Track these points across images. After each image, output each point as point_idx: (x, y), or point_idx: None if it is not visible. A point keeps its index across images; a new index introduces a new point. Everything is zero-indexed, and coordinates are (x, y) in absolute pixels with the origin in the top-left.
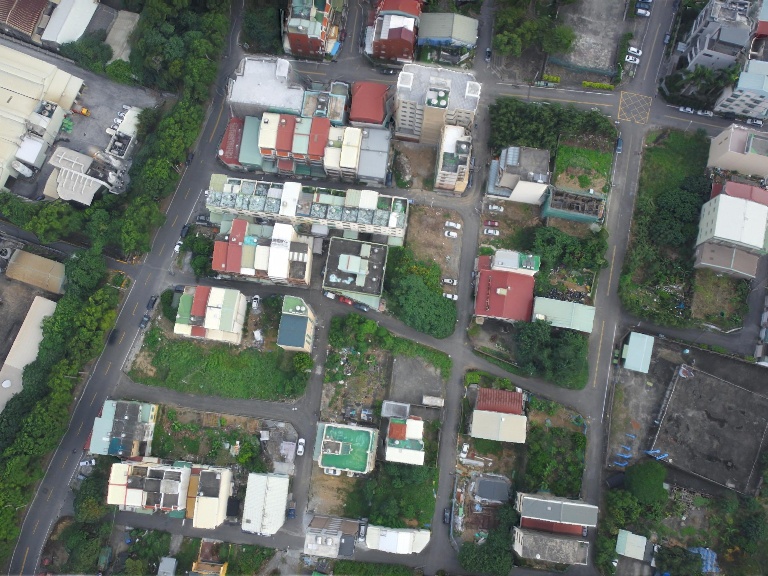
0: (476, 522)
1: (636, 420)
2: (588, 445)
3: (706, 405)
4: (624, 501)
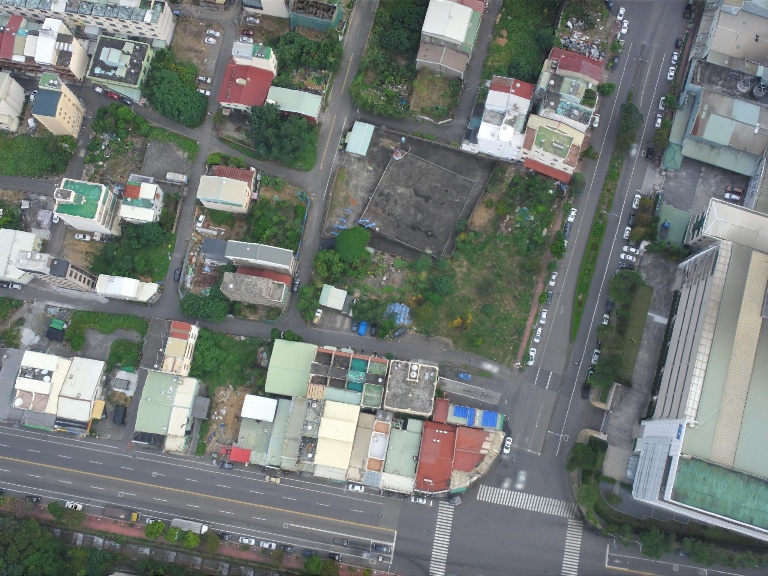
0: (204, 281)
1: (354, 198)
2: (309, 217)
3: (414, 184)
4: (325, 255)
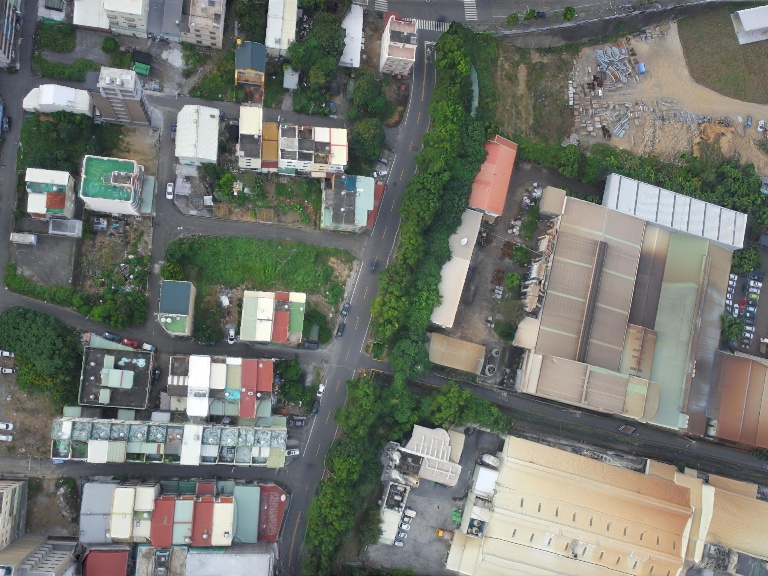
0: None
1: None
2: None
3: None
4: None
